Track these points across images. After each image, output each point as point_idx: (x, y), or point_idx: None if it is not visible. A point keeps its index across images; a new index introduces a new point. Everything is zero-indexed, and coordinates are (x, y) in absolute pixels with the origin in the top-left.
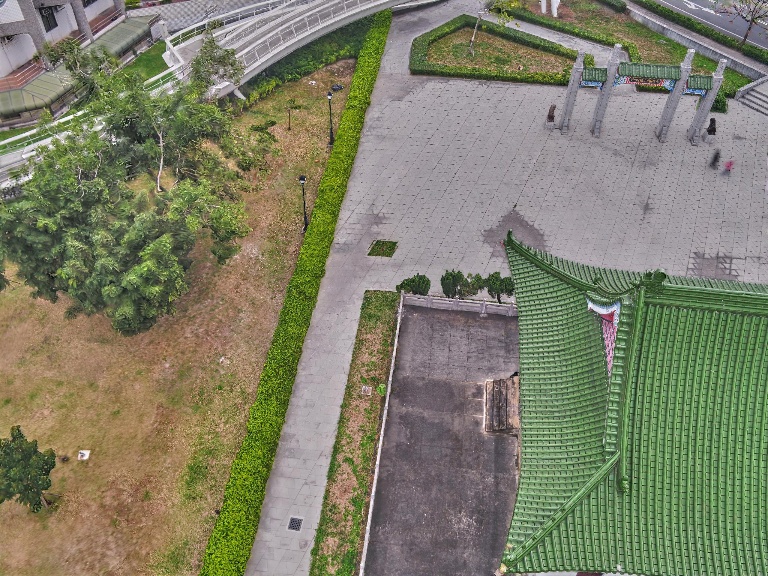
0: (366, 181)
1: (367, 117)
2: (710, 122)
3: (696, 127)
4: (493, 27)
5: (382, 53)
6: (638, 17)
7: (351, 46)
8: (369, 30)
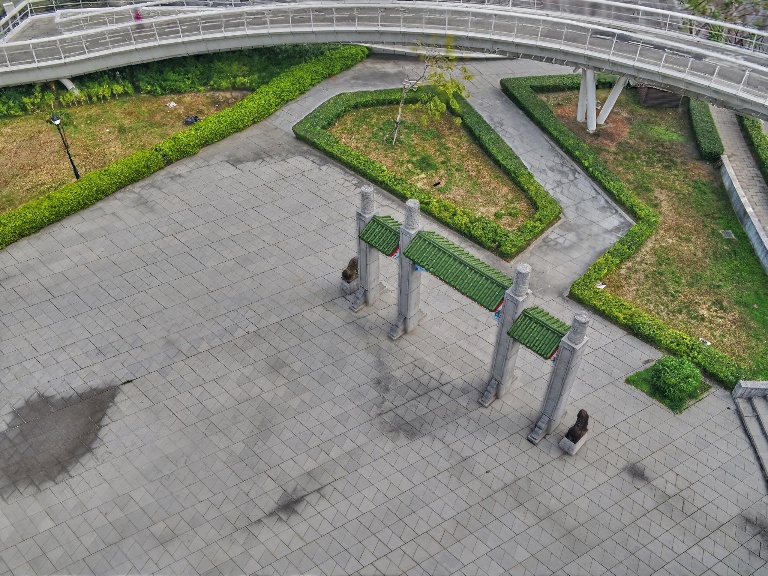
0: (40, 248)
1: (168, 169)
2: (578, 415)
3: (544, 410)
4: (463, 114)
5: (291, 98)
6: (726, 179)
7: (261, 76)
8: (299, 64)
